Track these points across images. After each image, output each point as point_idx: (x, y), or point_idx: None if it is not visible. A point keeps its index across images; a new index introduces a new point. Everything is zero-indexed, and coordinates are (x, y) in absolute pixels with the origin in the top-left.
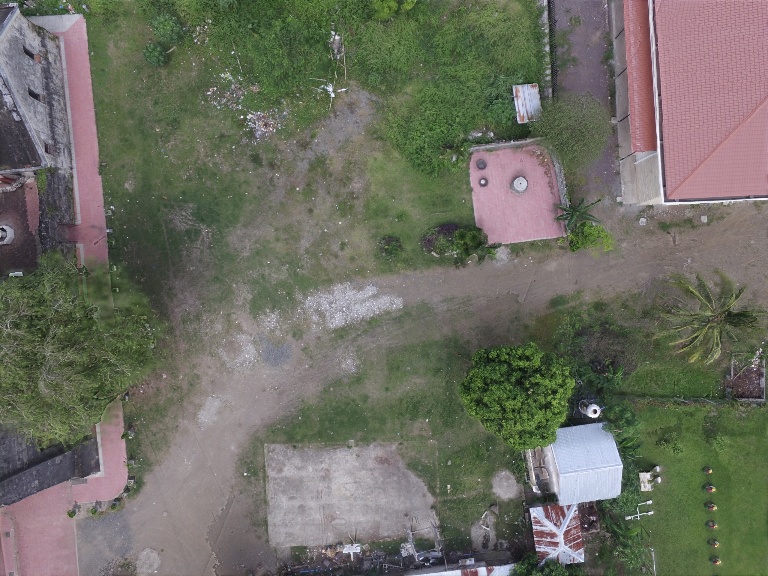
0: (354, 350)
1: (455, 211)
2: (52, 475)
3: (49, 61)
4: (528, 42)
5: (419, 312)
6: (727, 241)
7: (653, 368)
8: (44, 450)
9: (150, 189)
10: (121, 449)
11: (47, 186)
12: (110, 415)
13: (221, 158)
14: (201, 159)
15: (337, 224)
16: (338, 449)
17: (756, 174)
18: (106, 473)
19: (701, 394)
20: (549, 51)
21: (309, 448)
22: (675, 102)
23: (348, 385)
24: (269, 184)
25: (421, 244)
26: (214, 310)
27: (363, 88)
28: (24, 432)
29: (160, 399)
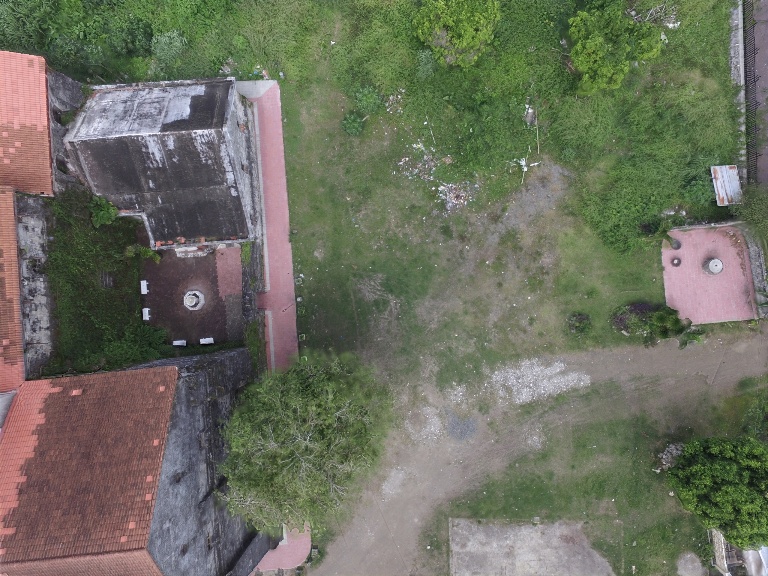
0: (540, 426)
1: (645, 290)
2: (258, 551)
3: (249, 129)
4: (726, 122)
5: (607, 390)
6: None
7: None
8: (248, 525)
9: (340, 258)
10: None
11: (250, 257)
12: None
13: (411, 229)
14: (392, 229)
15: (526, 299)
16: (523, 526)
17: None
18: (289, 541)
19: None
20: (745, 131)
21: (494, 524)
22: None
23: (534, 461)
24: (459, 256)
25: (610, 322)
26: (401, 381)
27: (556, 163)
28: (257, 518)
29: None
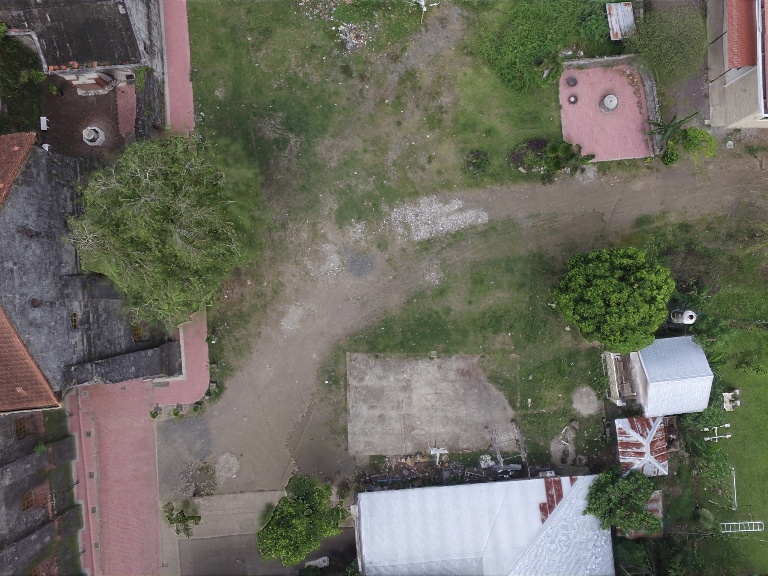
0: (438, 263)
1: (543, 128)
2: (145, 366)
3: None
4: None
5: (504, 227)
6: None
7: (735, 292)
8: (137, 342)
9: (240, 97)
10: (204, 353)
11: (144, 84)
12: (194, 319)
13: (311, 68)
14: (292, 68)
15: (425, 137)
16: (420, 360)
17: None
18: (188, 376)
19: None
20: None
21: (391, 358)
22: None
23: (431, 297)
24: (358, 96)
25: (508, 160)
26: (300, 219)
27: (455, 3)
28: (130, 310)
29: (244, 305)
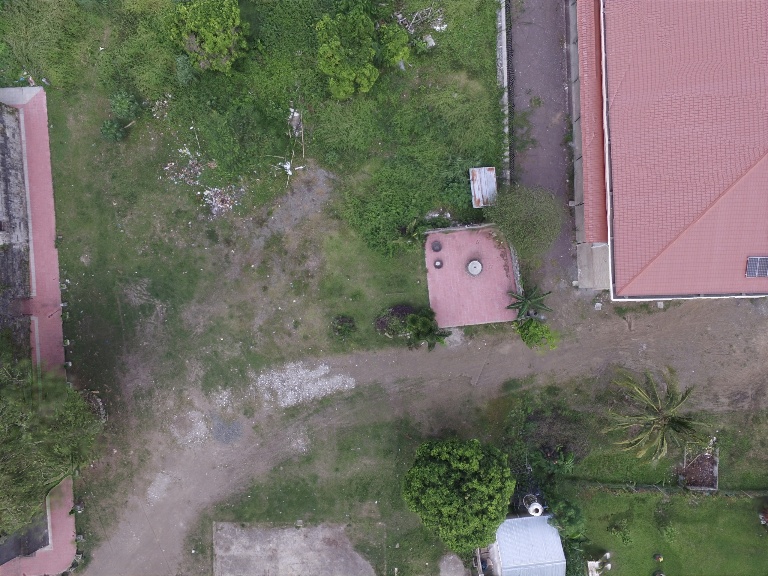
0: (305, 429)
1: (410, 292)
2: None
3: (7, 136)
4: (486, 124)
5: (371, 393)
6: (683, 328)
7: (606, 453)
8: None
9: (106, 263)
10: (70, 523)
11: None
12: (60, 488)
13: (177, 233)
14: (157, 234)
15: (291, 302)
16: (286, 529)
17: (706, 273)
18: (55, 546)
19: (654, 481)
20: (508, 133)
21: (257, 527)
22: (626, 199)
23: (298, 464)
24: (224, 260)
25: (375, 324)
26: (166, 386)
27: (320, 166)
28: None
29: (110, 474)
